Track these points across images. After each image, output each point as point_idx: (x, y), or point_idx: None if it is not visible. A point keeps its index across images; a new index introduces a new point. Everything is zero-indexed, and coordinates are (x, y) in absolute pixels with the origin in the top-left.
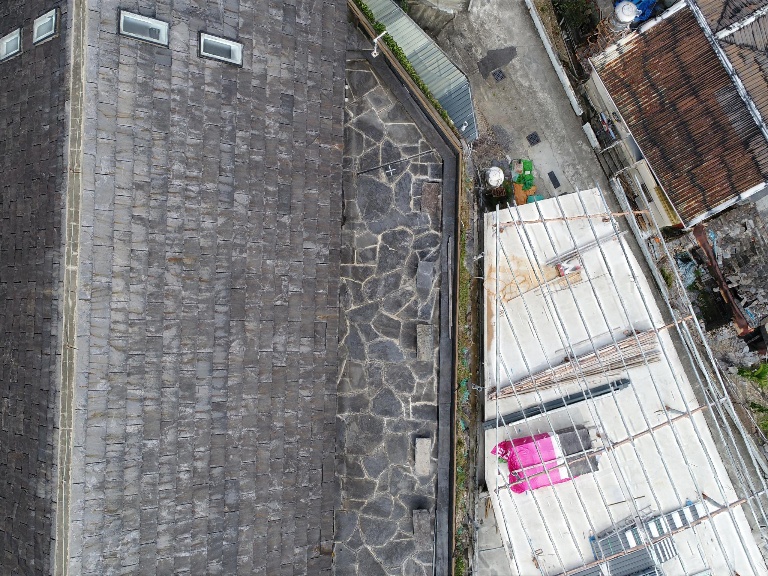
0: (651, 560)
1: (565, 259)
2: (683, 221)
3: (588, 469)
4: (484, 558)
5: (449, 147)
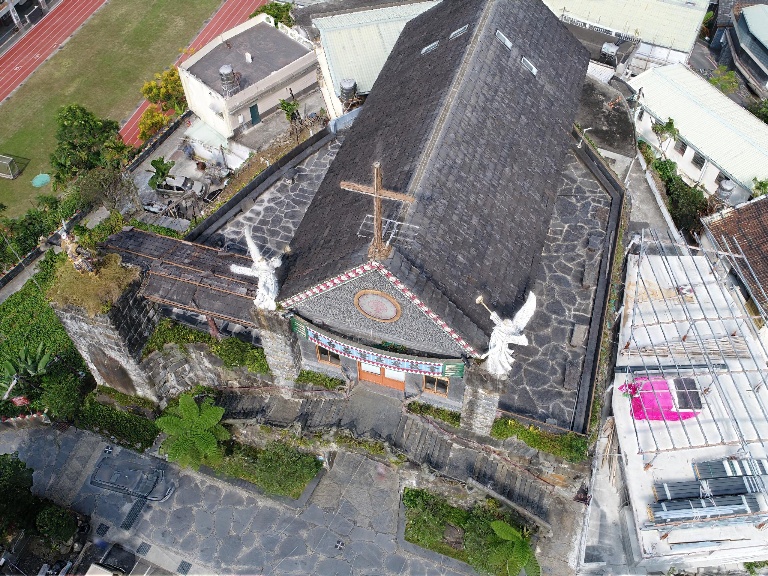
0: (744, 487)
1: None
2: (766, 314)
3: (694, 403)
4: (596, 499)
5: (617, 192)
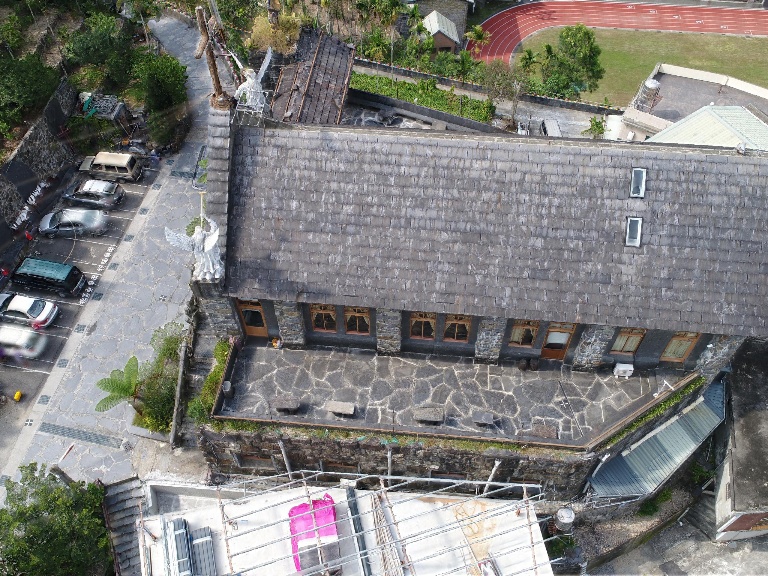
0: None
1: (494, 569)
2: None
3: (305, 565)
4: None
5: None
